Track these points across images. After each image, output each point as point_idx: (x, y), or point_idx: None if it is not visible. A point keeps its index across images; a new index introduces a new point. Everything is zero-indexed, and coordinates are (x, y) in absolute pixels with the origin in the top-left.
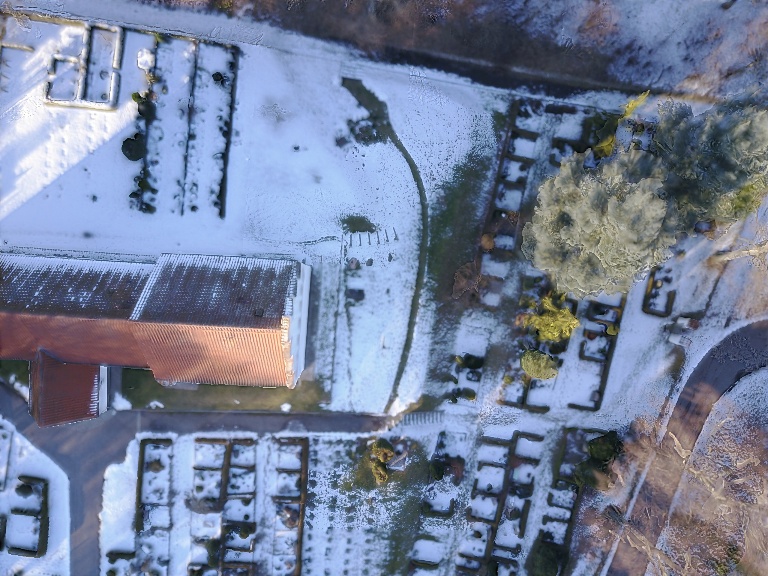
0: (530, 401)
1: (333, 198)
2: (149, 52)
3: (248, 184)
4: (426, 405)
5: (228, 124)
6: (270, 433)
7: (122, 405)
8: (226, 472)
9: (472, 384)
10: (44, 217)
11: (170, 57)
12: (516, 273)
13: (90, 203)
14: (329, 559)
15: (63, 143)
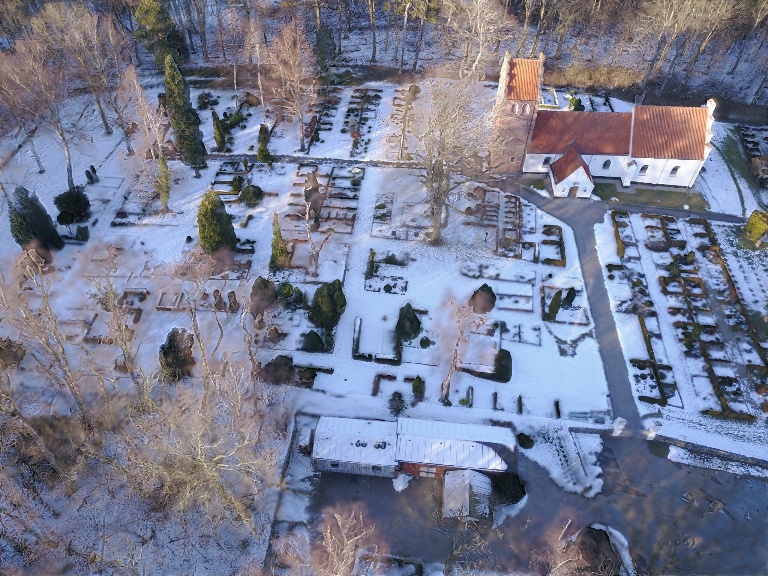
0: None
1: None
2: (569, 95)
3: None
4: None
5: None
6: (682, 218)
7: (596, 198)
8: None
9: None
10: None
11: (577, 98)
12: None
13: None
14: (749, 282)
15: None
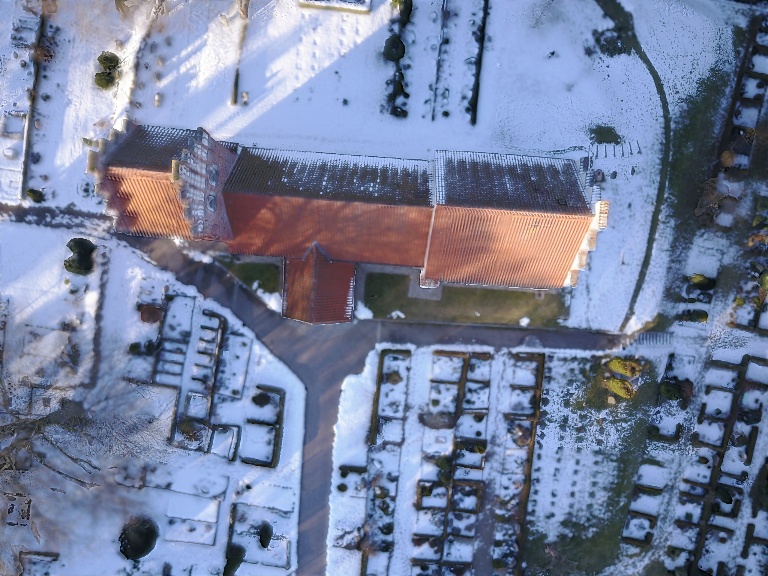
0: (761, 325)
1: (583, 107)
2: None
3: (499, 90)
4: (660, 325)
5: (481, 28)
6: (507, 348)
7: (364, 314)
8: (464, 386)
9: (703, 306)
10: (294, 120)
11: None
12: (750, 193)
13: (340, 106)
14: (557, 480)
15: (314, 45)
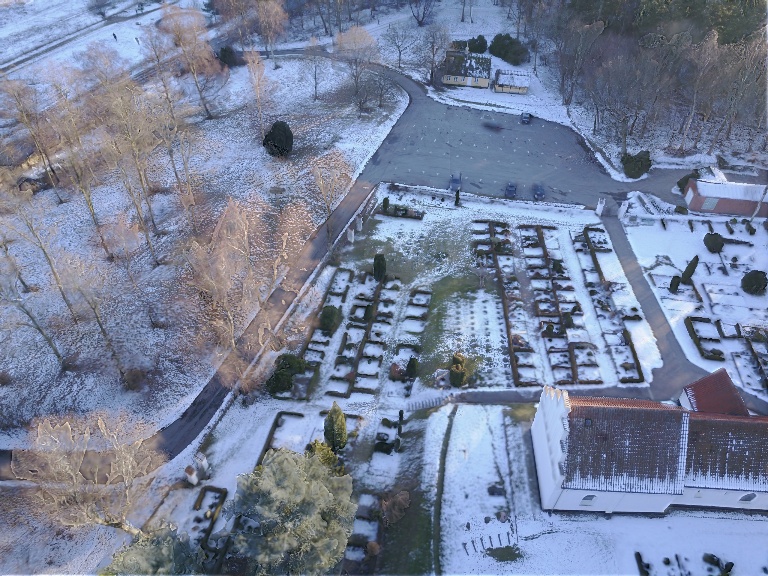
0: None
1: None
2: None
3: None
4: (423, 412)
5: None
6: None
7: None
8: (574, 363)
9: (384, 431)
10: None
11: None
12: None
13: None
14: (485, 319)
15: None
